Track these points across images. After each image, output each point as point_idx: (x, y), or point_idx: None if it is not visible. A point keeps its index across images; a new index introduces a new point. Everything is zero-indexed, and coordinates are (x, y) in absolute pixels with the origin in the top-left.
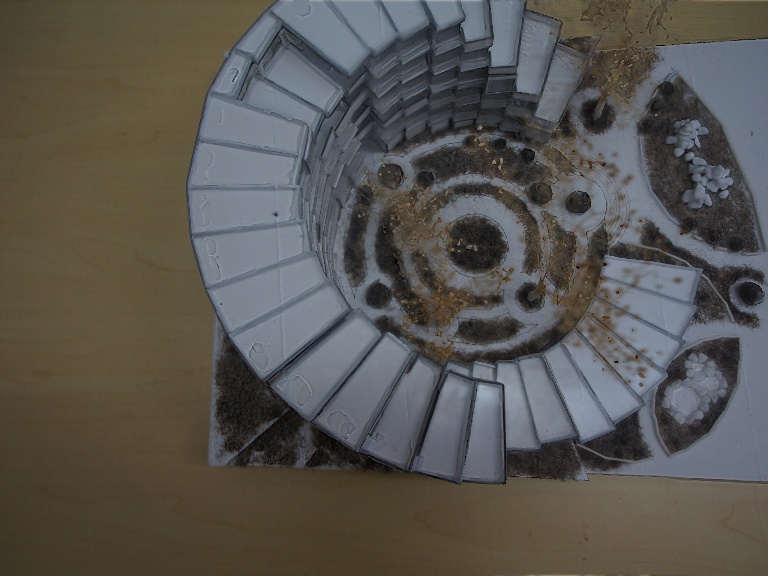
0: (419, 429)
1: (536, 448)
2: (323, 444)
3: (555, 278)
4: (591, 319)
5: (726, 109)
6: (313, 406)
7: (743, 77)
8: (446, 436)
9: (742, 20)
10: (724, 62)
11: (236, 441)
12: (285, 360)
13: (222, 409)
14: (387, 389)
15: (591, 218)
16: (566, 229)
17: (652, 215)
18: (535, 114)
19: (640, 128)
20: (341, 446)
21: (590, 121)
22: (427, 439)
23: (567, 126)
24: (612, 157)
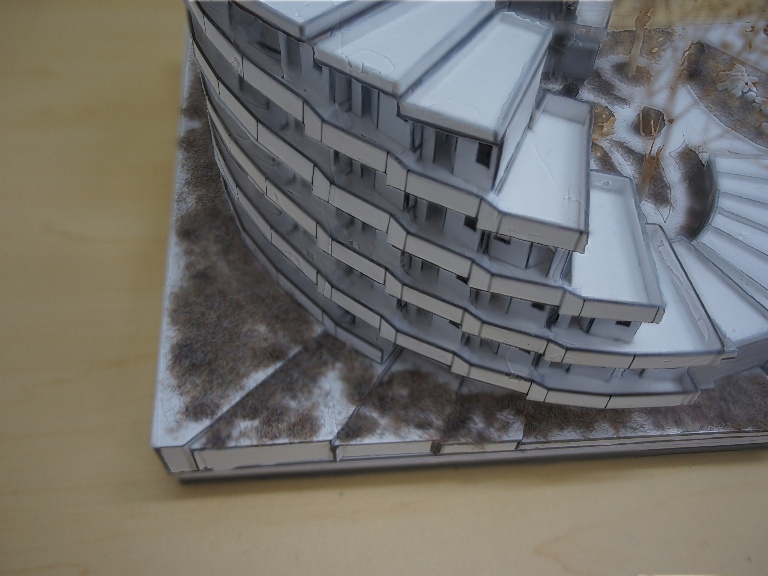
0: (582, 174)
1: (730, 349)
2: (364, 402)
3: (650, 196)
4: (724, 215)
5: (765, 66)
6: (400, 73)
7: (767, 45)
8: (607, 260)
9: (740, 17)
10: (742, 36)
11: (207, 402)
12: (342, 3)
13: (181, 355)
14: (526, 65)
15: (669, 140)
16: (642, 152)
17: (734, 148)
18: (576, 22)
19: (683, 79)
20: (396, 402)
21: (625, 77)
22: (575, 268)
23: (601, 81)
24: (663, 103)
